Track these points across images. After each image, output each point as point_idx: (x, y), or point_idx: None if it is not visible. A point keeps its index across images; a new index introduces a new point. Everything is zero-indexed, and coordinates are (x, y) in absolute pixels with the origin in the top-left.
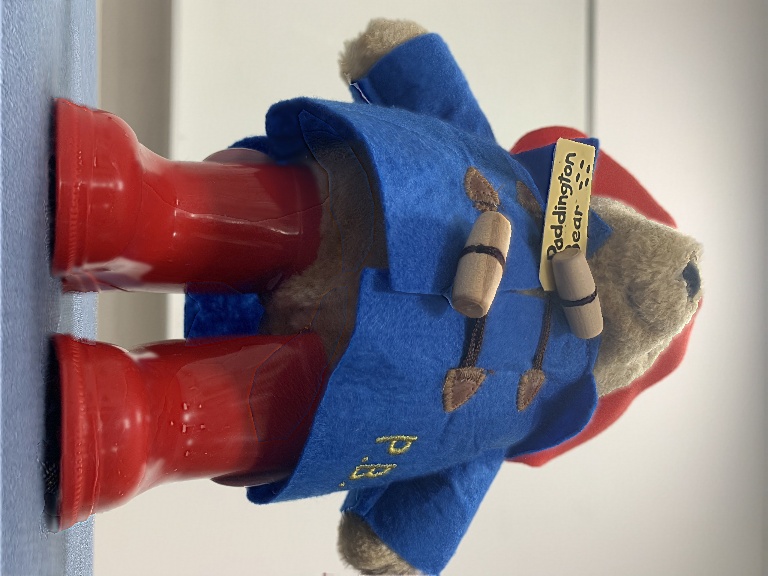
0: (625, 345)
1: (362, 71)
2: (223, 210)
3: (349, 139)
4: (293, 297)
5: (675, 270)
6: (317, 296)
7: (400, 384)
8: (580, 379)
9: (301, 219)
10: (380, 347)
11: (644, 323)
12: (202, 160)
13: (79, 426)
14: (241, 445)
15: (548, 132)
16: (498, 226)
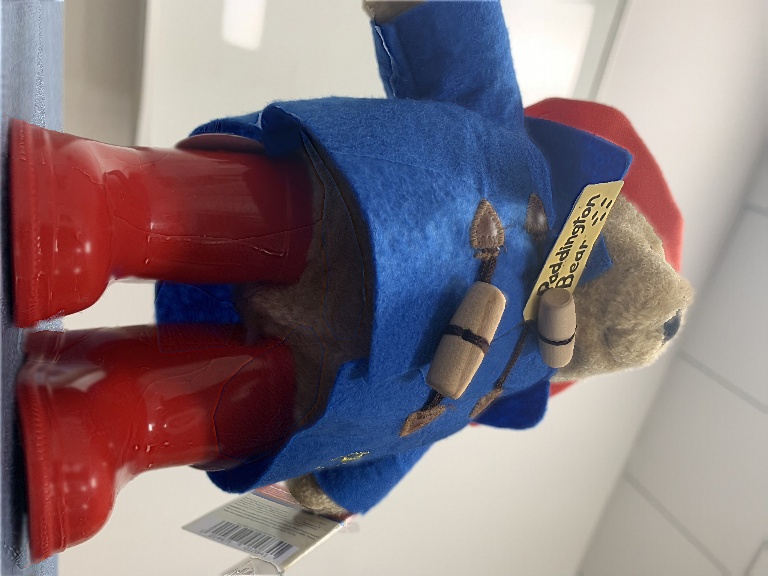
0: (587, 370)
1: (389, 12)
2: (203, 230)
3: (352, 210)
4: (269, 312)
5: (658, 322)
6: (294, 321)
7: (361, 431)
8: (536, 384)
9: (288, 240)
10: (347, 419)
11: (611, 358)
12: (184, 143)
13: (44, 514)
14: (202, 455)
15: (584, 107)
16: (492, 309)
